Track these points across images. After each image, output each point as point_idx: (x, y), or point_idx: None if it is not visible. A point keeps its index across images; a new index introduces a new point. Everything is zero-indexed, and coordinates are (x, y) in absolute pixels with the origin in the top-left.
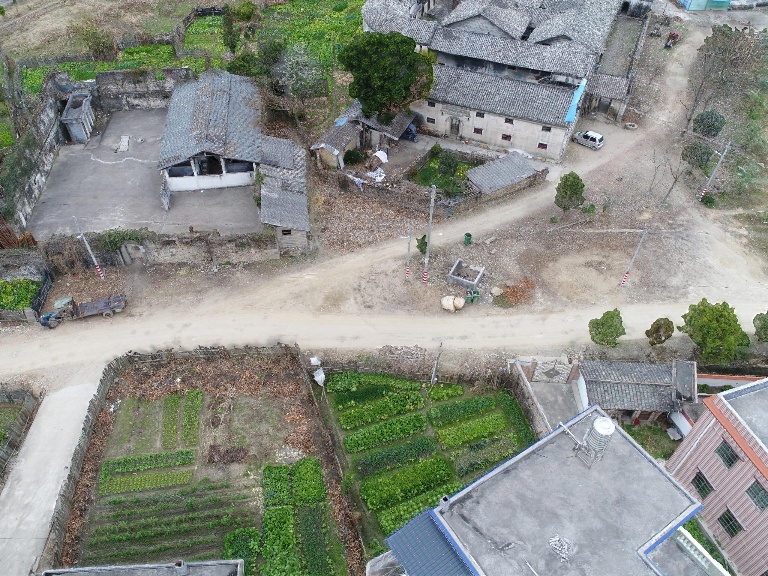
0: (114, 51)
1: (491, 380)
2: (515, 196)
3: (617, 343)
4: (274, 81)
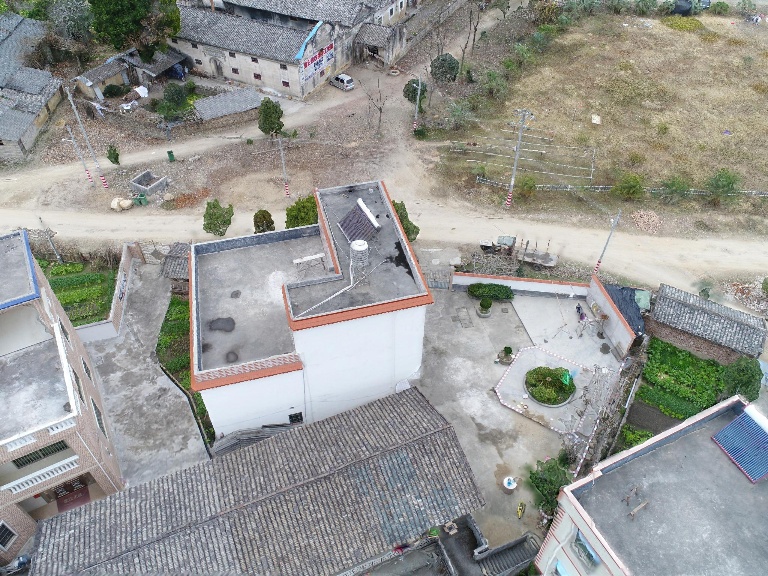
0: None
1: (105, 259)
2: (242, 125)
3: (221, 231)
4: (71, 26)
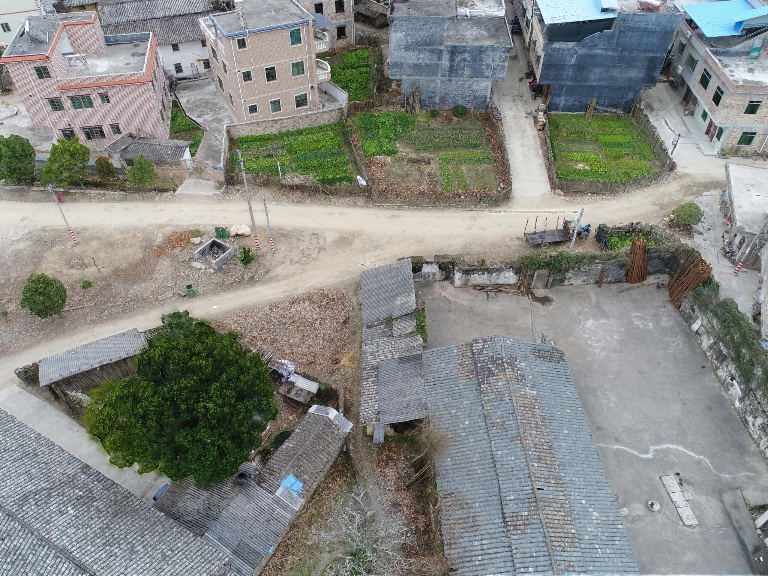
0: None
1: None
2: None
3: None
4: None
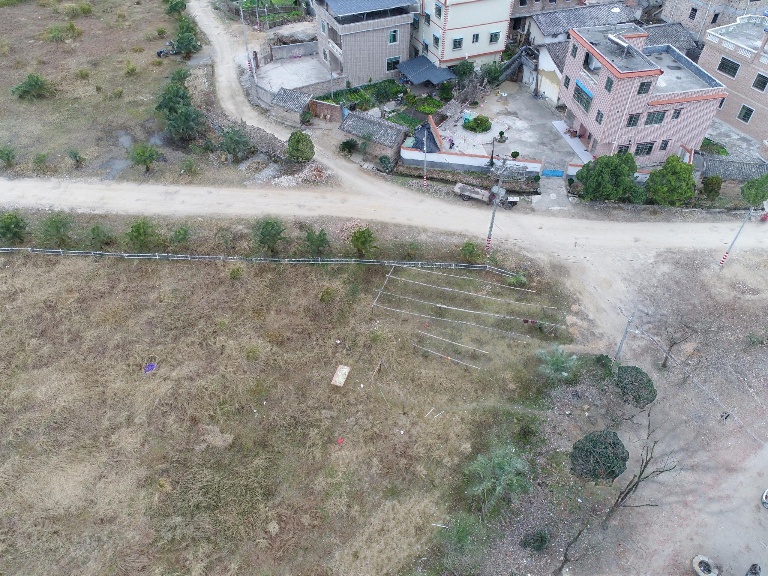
0: None
1: None
2: None
3: None
4: None
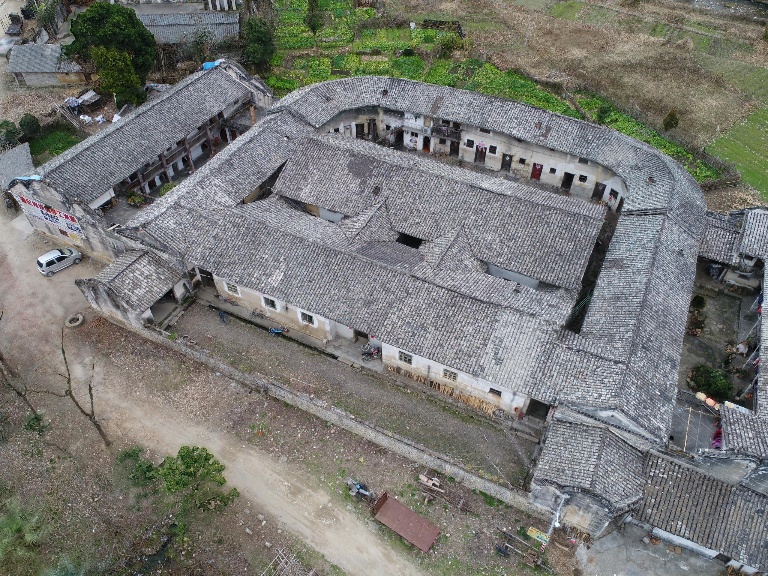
0: (358, 1)
1: None
2: None
3: None
4: None
